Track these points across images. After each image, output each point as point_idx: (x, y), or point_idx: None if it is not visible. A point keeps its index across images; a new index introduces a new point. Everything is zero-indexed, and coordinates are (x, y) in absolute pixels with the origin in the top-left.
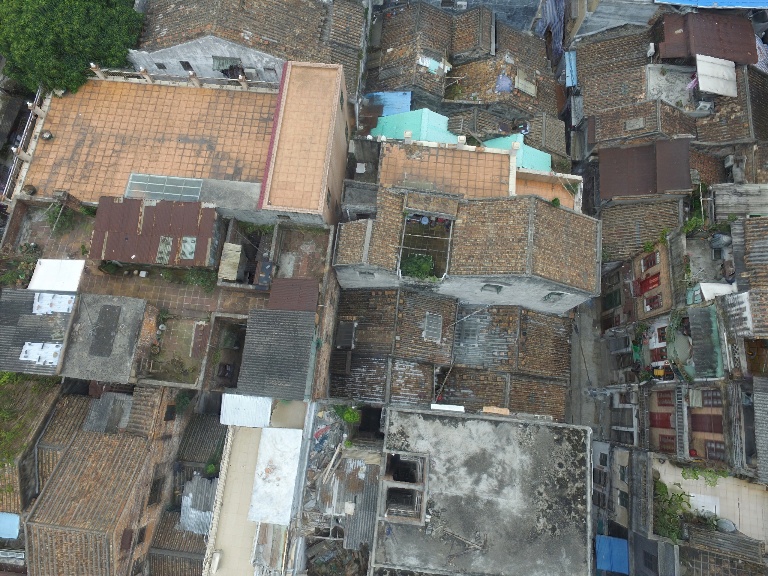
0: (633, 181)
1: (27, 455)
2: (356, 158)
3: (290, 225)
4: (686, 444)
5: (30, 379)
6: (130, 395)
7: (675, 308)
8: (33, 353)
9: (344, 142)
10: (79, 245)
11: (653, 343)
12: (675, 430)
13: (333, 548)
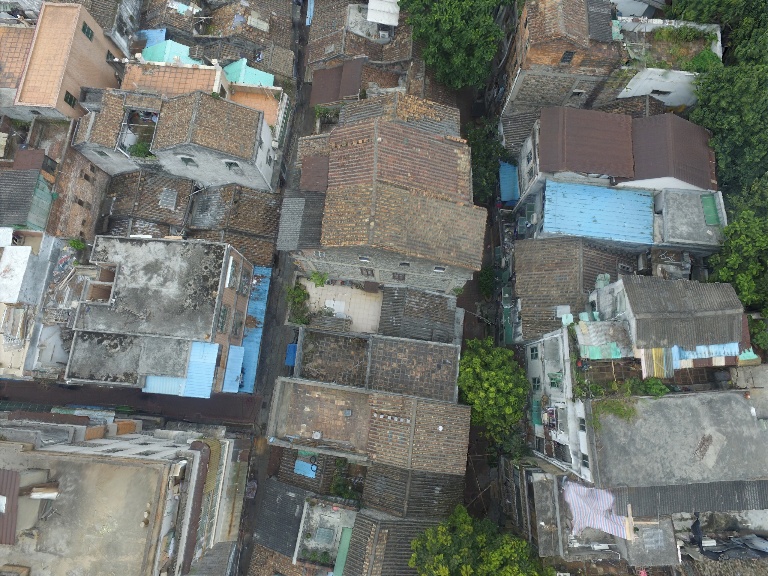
0: (330, 92)
1: None
2: (121, 79)
3: (43, 119)
4: None
5: None
6: None
7: None
8: None
9: (106, 66)
10: None
11: None
12: None
13: None
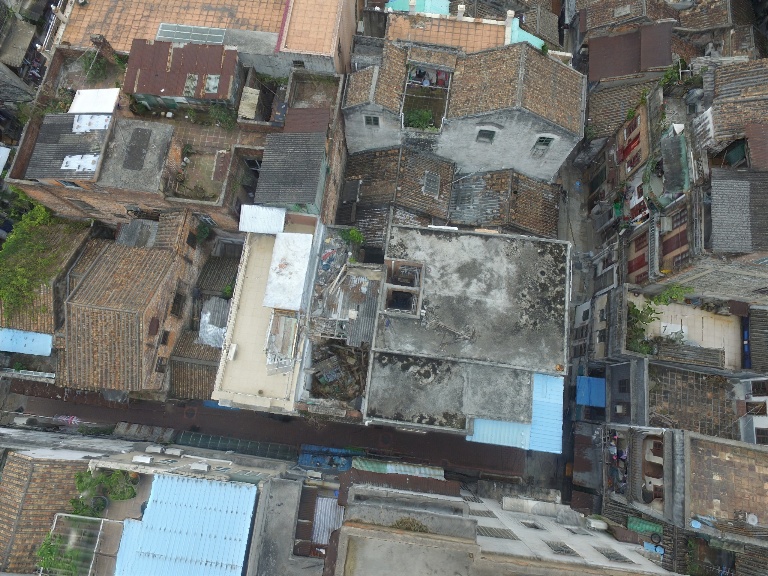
0: (619, 64)
1: (60, 280)
2: None
3: (304, 74)
4: (656, 262)
5: (62, 223)
6: (156, 221)
7: (652, 155)
8: (73, 163)
9: (354, 18)
10: None
11: (633, 202)
12: (648, 258)
13: (336, 370)
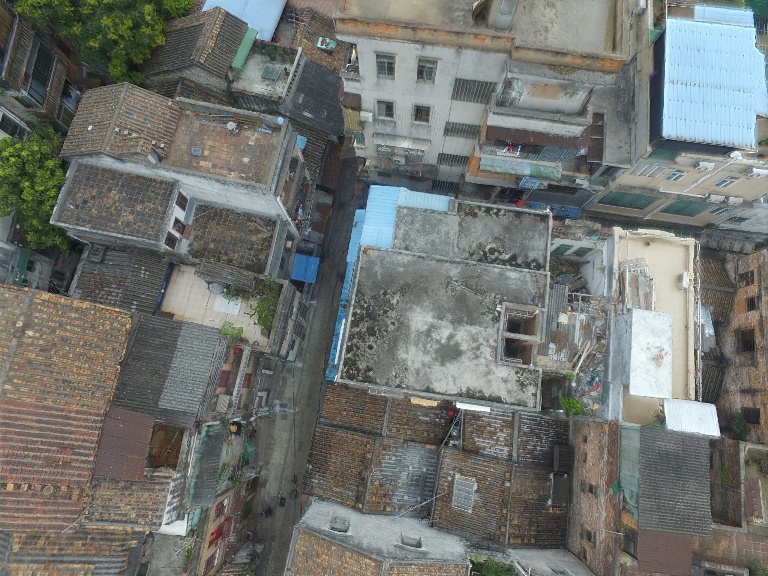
0: None
1: None
2: None
3: None
4: (244, 360)
5: None
6: None
7: None
8: None
9: None
10: None
11: None
12: None
13: None
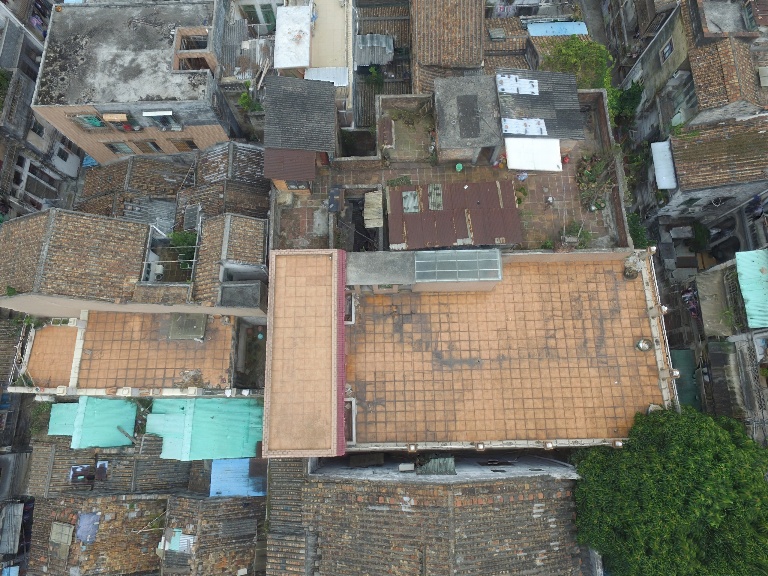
0: None
1: None
2: None
3: None
4: None
5: None
6: None
7: None
8: (526, 85)
9: None
10: (546, 217)
11: None
12: None
13: None
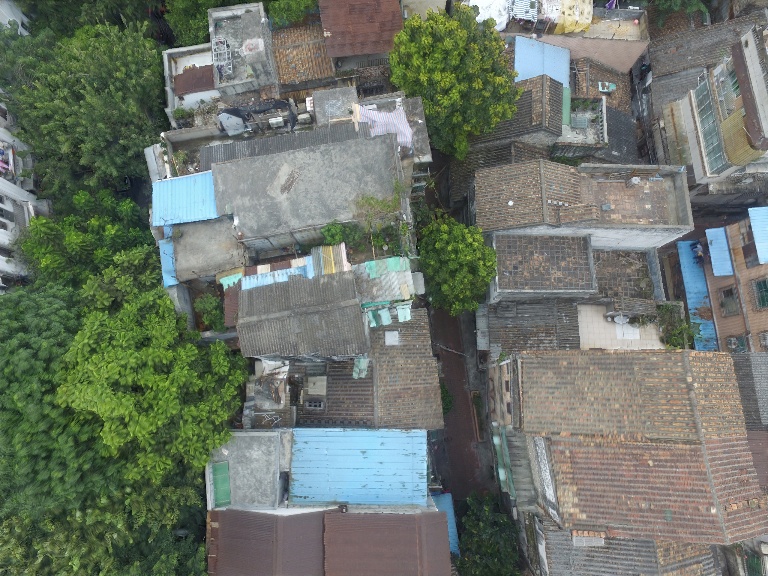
0: None
1: None
2: None
3: None
4: None
5: None
6: None
7: None
8: None
9: None
10: None
11: None
12: None
13: None
